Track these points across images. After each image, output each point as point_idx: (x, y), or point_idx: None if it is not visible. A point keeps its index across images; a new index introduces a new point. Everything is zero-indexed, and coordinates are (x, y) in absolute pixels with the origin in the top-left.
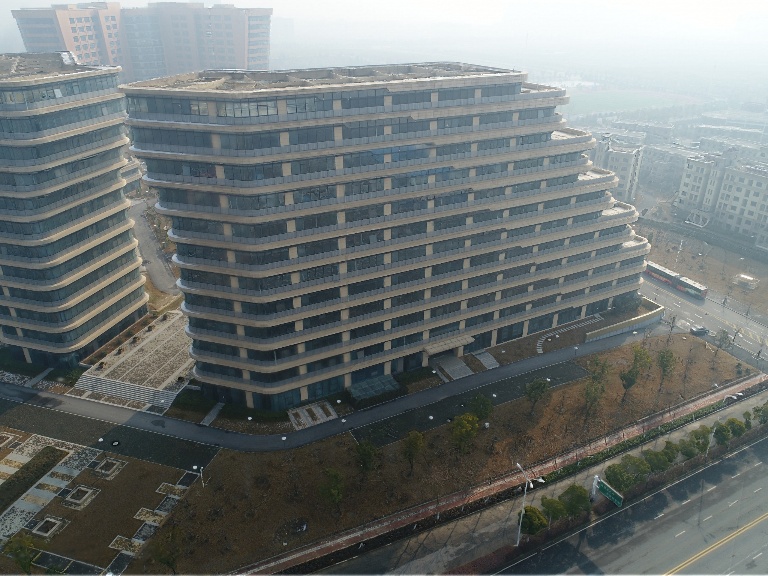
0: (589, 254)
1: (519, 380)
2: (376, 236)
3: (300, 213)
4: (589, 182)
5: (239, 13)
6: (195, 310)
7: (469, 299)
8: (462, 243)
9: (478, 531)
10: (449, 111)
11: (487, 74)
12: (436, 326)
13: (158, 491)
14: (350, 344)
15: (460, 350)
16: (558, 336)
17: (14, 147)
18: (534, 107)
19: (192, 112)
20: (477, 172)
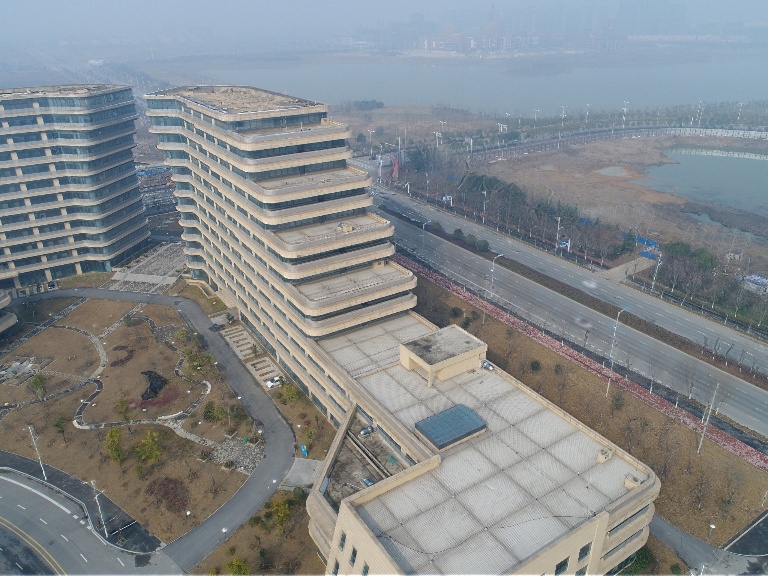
0: None
1: None
2: None
3: None
4: None
5: None
6: None
7: None
8: None
9: None
10: None
11: None
12: None
13: (167, 225)
14: None
15: None
16: None
17: None
18: None
19: None
20: None
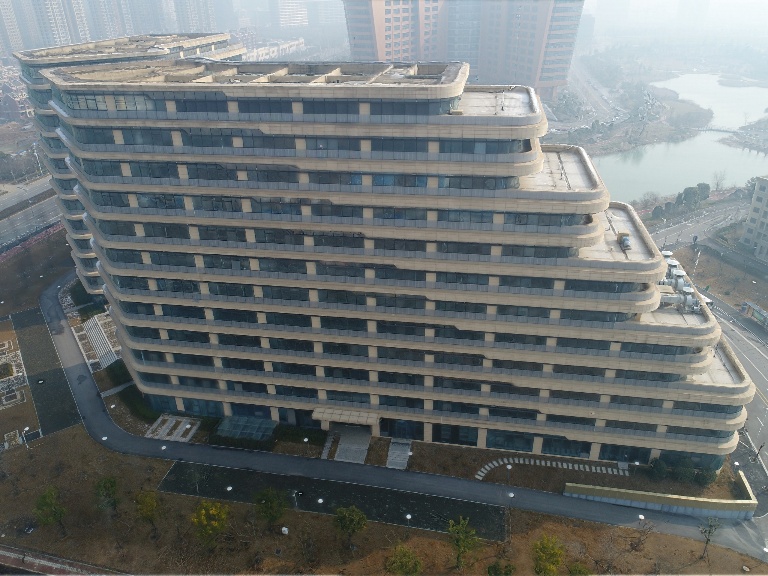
0: (600, 371)
1: (400, 498)
2: (240, 263)
3: (141, 218)
4: (591, 264)
5: None
6: (107, 288)
7: (378, 371)
8: (363, 299)
9: None
10: (315, 128)
11: (376, 83)
12: (330, 388)
13: (6, 435)
14: (224, 372)
15: (375, 429)
16: (509, 467)
17: None
18: (460, 137)
19: None
20: (376, 213)
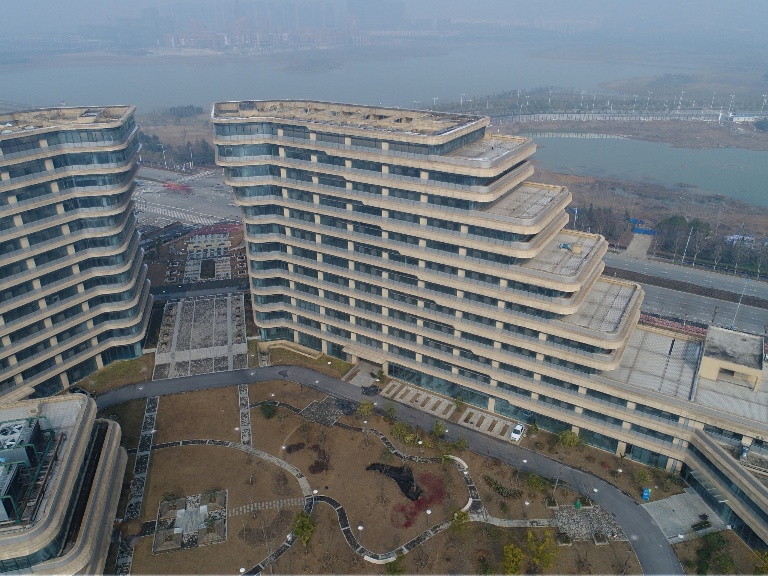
0: None
1: None
2: None
3: None
4: None
5: None
6: None
7: None
8: None
9: None
10: None
11: None
12: None
13: None
14: None
15: None
16: None
17: None
18: None
19: None
20: None
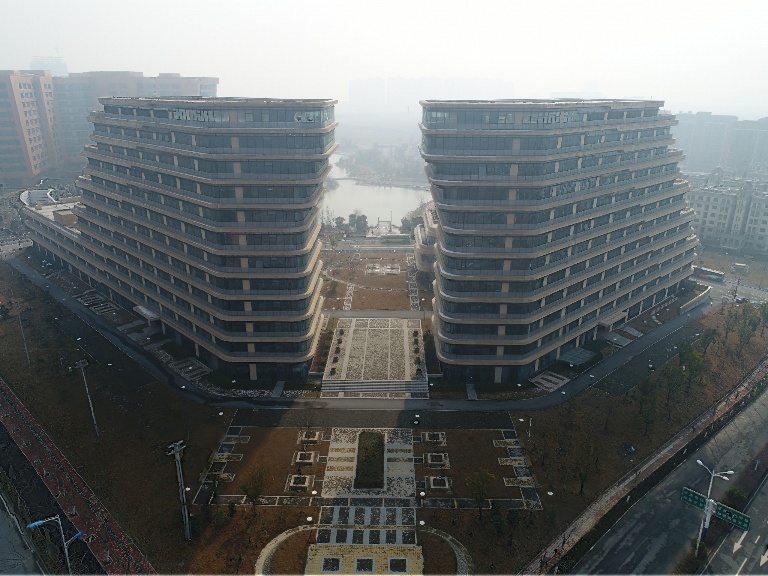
0: (673, 245)
1: (668, 341)
2: (587, 225)
3: (561, 203)
4: (679, 186)
5: (190, 81)
6: (462, 296)
7: (621, 280)
8: (622, 233)
9: (744, 432)
10: (632, 126)
11: None
12: (606, 303)
13: (496, 445)
14: (564, 319)
15: (611, 326)
16: (668, 309)
17: (303, 162)
18: (665, 126)
19: (498, 121)
20: (635, 175)
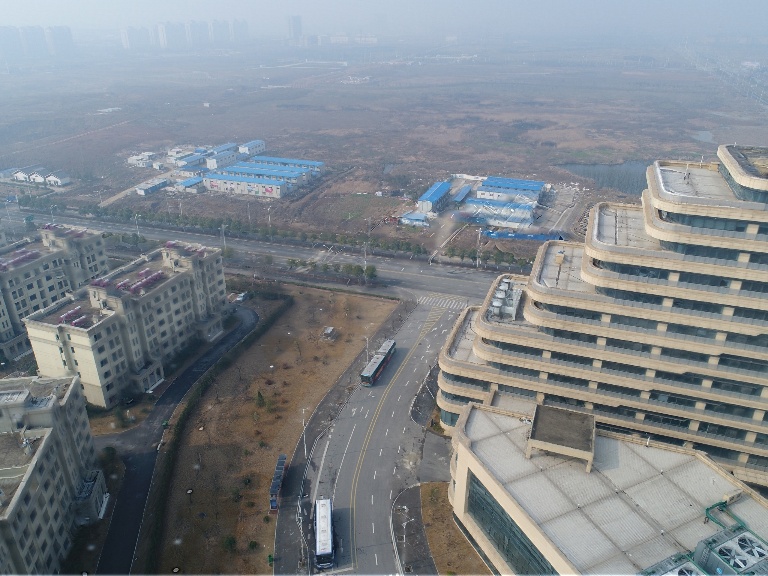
0: None
1: None
2: None
3: None
4: None
5: None
6: None
7: None
8: None
9: None
10: None
11: None
12: None
13: None
14: None
15: None
16: None
17: None
18: None
19: None
20: None
